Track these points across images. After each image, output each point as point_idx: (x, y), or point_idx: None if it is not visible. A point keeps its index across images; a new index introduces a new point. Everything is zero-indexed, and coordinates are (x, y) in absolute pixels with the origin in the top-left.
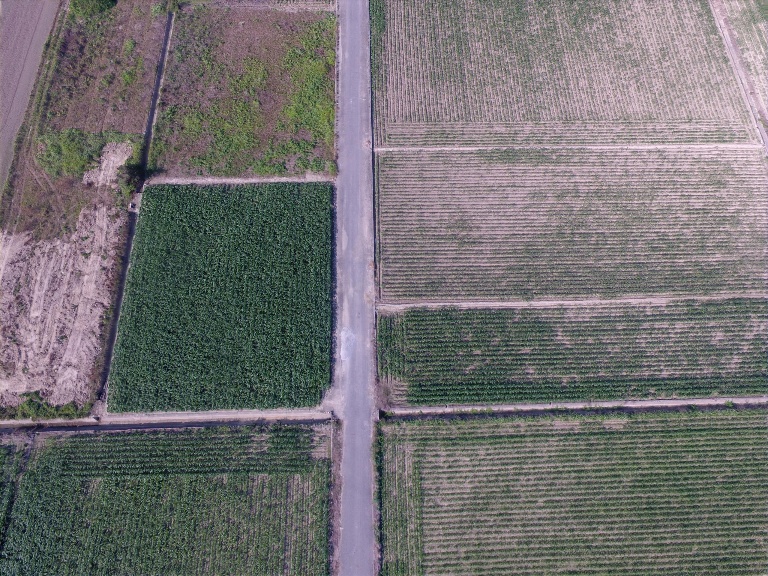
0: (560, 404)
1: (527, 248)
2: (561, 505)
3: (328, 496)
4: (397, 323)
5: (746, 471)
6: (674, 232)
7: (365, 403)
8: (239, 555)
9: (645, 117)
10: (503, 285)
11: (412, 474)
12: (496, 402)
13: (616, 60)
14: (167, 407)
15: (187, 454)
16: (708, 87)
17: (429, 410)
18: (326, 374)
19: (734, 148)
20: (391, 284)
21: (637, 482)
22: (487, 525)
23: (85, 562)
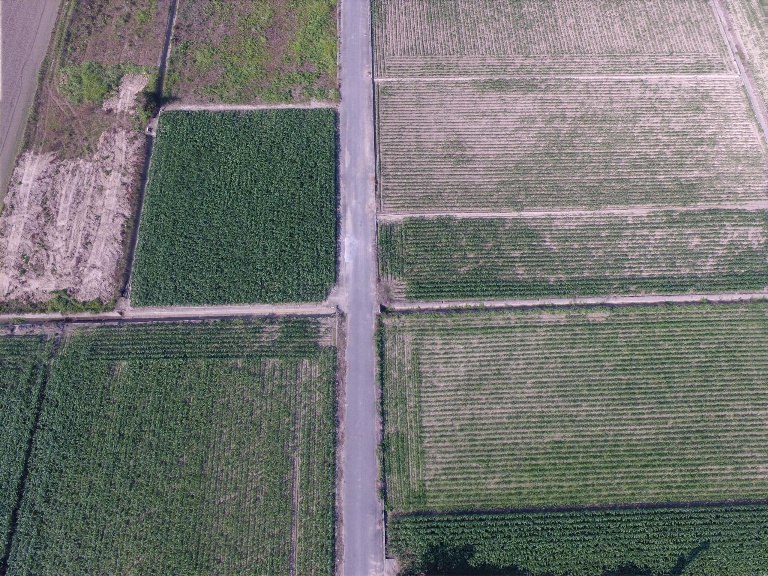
0: (547, 300)
1: (517, 166)
2: (548, 386)
3: (334, 378)
4: (397, 231)
5: (718, 357)
6: (655, 152)
7: (367, 299)
8: (253, 427)
9: (629, 51)
10: (495, 198)
11: (411, 359)
12: (488, 297)
13: (602, 0)
14: (185, 302)
15: (204, 341)
16: (689, 24)
17: (426, 306)
18: (331, 273)
19: (712, 78)
20: (391, 197)
21: (618, 366)
22: (480, 402)
23: (113, 432)
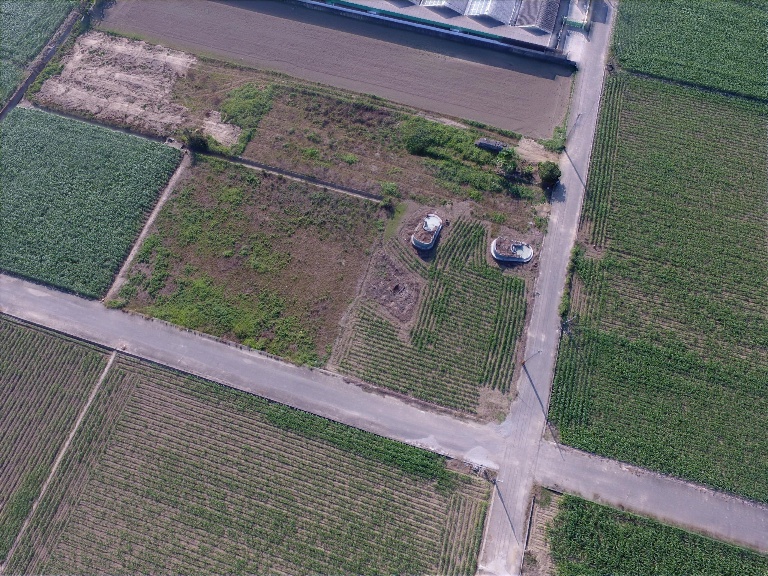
0: None
1: None
2: None
3: None
4: None
5: None
6: None
7: None
8: None
9: None
10: None
11: None
12: None
13: None
14: None
15: None
16: None
17: None
18: None
19: None
20: None
21: None
22: None
23: None
